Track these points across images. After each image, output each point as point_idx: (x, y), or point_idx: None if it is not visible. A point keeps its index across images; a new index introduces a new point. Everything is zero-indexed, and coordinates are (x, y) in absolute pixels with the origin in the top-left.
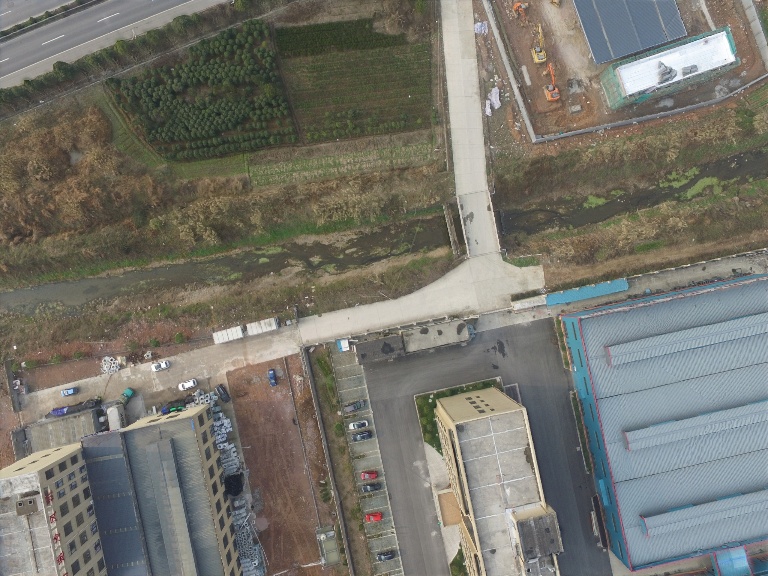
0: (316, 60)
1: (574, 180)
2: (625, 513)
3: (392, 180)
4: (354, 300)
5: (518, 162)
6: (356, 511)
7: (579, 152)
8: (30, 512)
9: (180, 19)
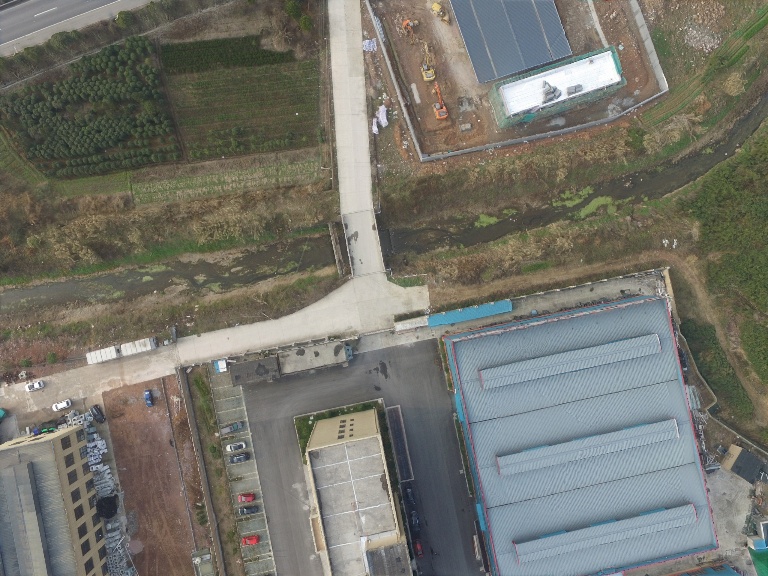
0: (202, 77)
1: (464, 199)
2: (498, 539)
3: (276, 198)
4: (234, 320)
5: (405, 181)
6: (230, 535)
7: (467, 171)
8: None
9: (58, 36)
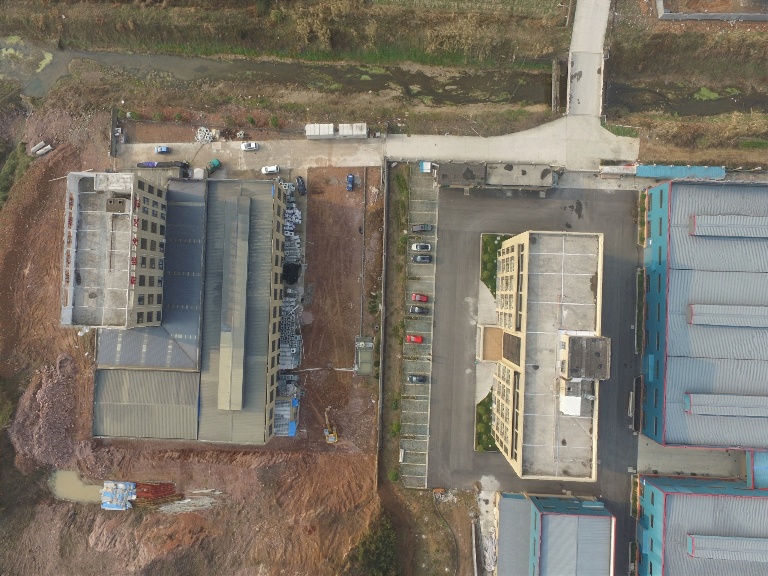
0: None
1: (691, 67)
2: (671, 387)
3: (509, 24)
4: (445, 129)
5: (639, 33)
6: (400, 325)
7: (705, 36)
8: (118, 211)
9: None
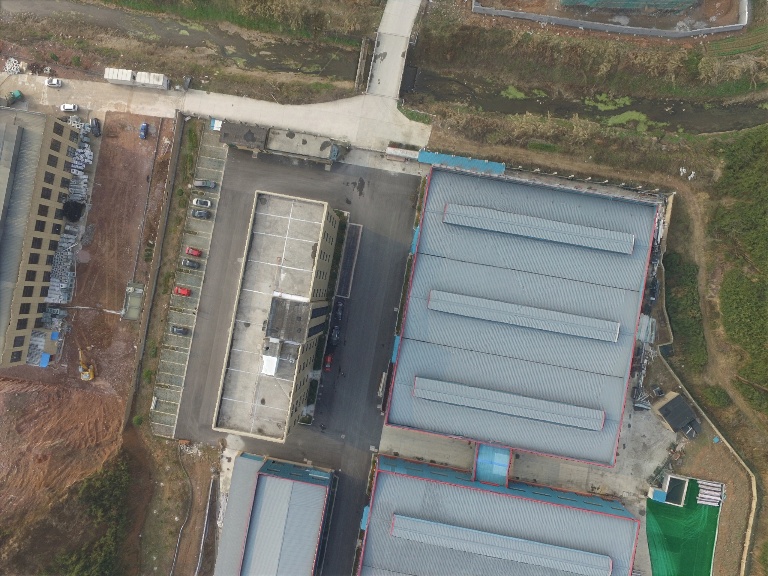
0: None
1: (500, 64)
2: (402, 368)
3: None
4: (244, 91)
5: (449, 22)
6: (166, 275)
7: (512, 33)
8: None
9: None
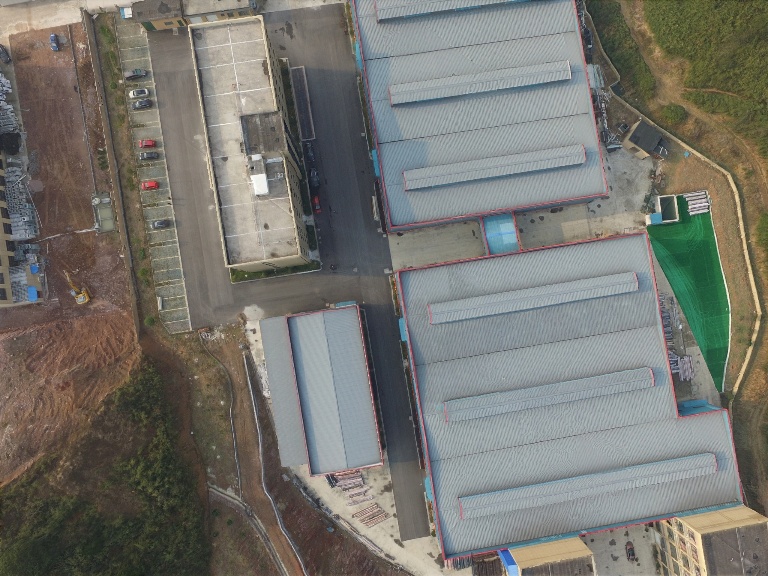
0: None
1: None
2: (388, 171)
3: None
4: None
5: None
6: (127, 171)
7: None
8: None
9: None
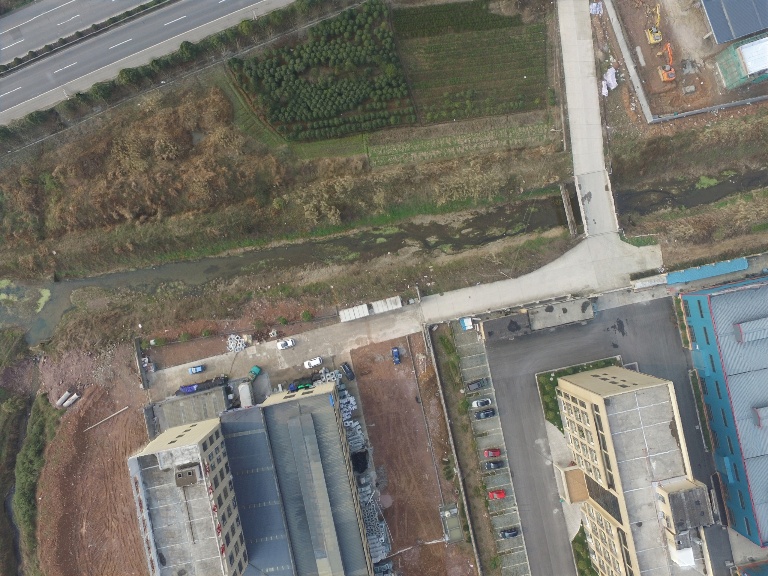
0: (433, 41)
1: (687, 161)
2: (754, 489)
3: (510, 160)
4: (475, 279)
5: (635, 142)
6: (482, 488)
7: (695, 132)
8: (189, 483)
9: None
